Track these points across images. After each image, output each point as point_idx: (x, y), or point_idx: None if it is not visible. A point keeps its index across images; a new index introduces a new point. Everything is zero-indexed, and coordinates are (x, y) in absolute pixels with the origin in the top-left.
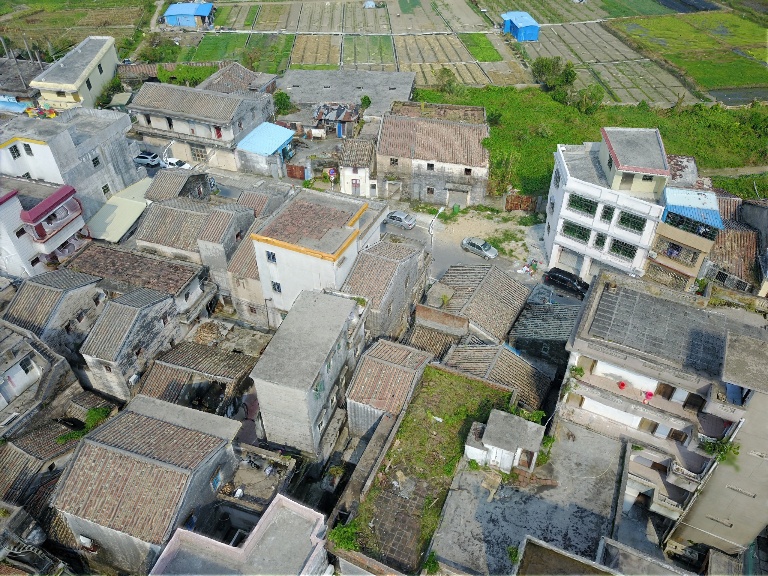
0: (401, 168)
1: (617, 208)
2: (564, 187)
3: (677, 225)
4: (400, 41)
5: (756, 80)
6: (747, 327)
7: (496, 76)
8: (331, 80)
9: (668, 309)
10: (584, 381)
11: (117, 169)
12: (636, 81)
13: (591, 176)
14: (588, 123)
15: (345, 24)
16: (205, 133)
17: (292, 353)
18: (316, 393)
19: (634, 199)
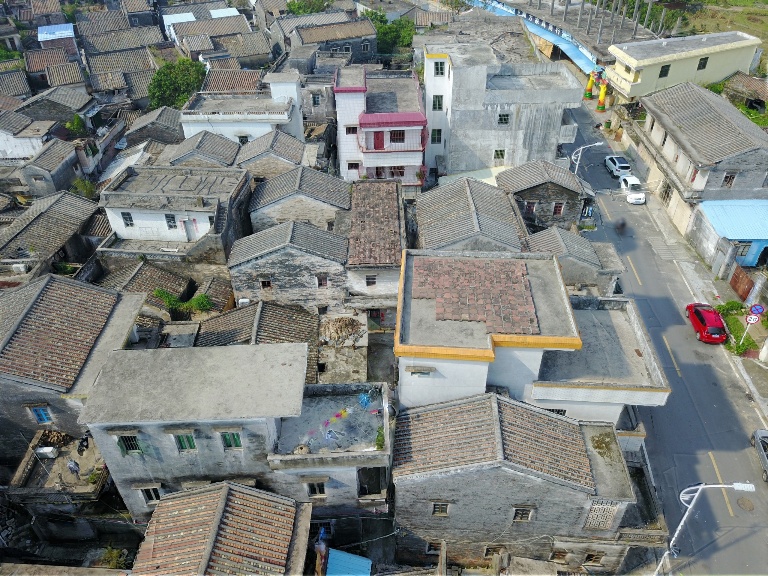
0: None
1: None
2: None
3: None
4: None
5: None
6: None
7: None
8: None
9: None
10: None
11: (528, 142)
12: None
13: None
14: None
15: None
16: (685, 167)
17: (159, 378)
18: (118, 444)
19: None
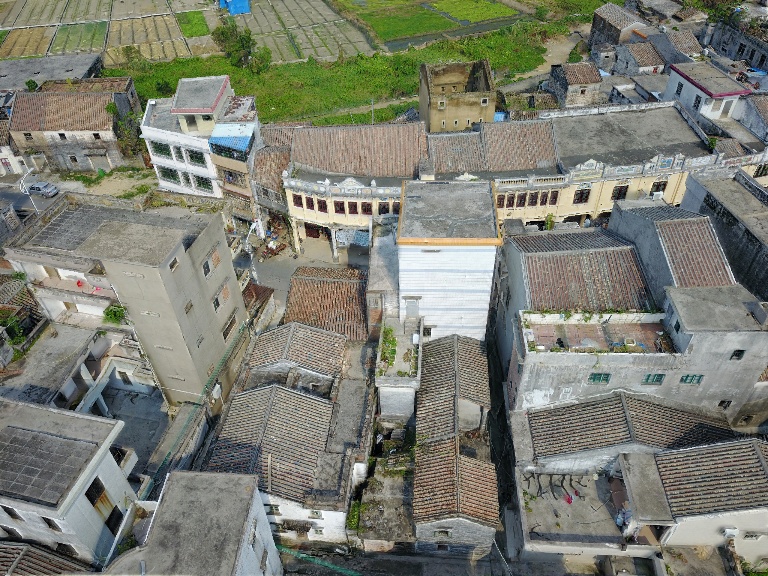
0: (37, 141)
1: (182, 147)
2: (141, 135)
3: (220, 154)
4: (116, 26)
5: (429, 29)
6: (166, 219)
7: (198, 49)
8: (10, 69)
9: (111, 215)
10: (51, 286)
11: None
12: (326, 40)
13: (170, 123)
14: (254, 82)
15: (65, 15)
16: None
17: None
18: None
19: (187, 137)
